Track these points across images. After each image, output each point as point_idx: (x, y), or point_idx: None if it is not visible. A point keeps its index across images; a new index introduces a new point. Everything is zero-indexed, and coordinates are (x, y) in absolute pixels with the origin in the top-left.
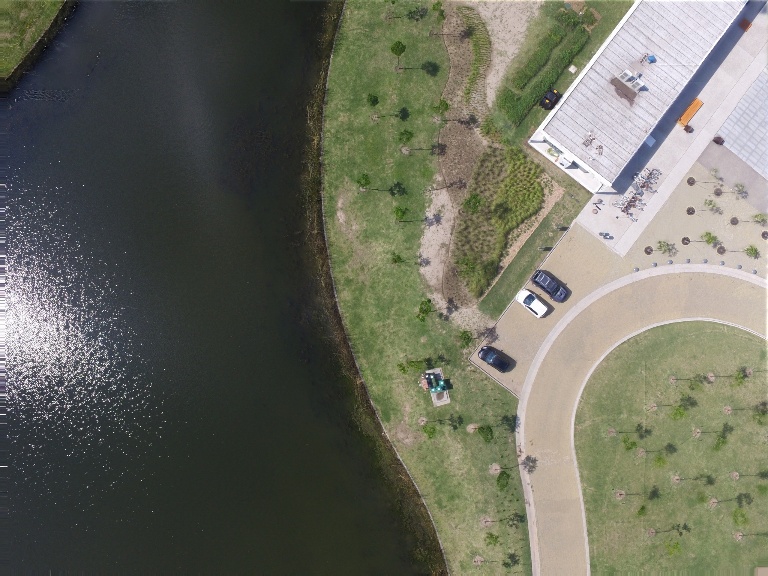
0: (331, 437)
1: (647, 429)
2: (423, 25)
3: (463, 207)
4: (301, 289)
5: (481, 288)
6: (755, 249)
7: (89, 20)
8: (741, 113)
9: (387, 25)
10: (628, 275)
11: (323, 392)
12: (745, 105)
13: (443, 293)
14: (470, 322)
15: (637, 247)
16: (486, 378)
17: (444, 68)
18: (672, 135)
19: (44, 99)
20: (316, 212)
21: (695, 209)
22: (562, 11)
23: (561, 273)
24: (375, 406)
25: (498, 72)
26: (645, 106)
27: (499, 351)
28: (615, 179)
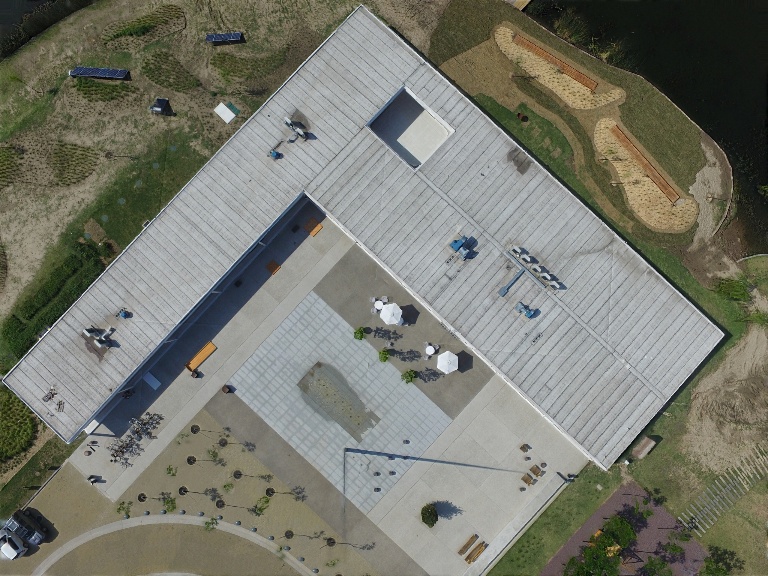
0: None
1: None
2: None
3: None
4: None
5: None
6: None
7: None
8: (258, 361)
9: None
10: (118, 521)
11: None
12: (263, 352)
13: None
14: None
15: (130, 493)
16: None
17: None
18: (180, 379)
19: None
20: None
21: (196, 458)
22: (76, 243)
23: (49, 512)
24: None
25: (9, 299)
26: (114, 363)
27: None
28: None
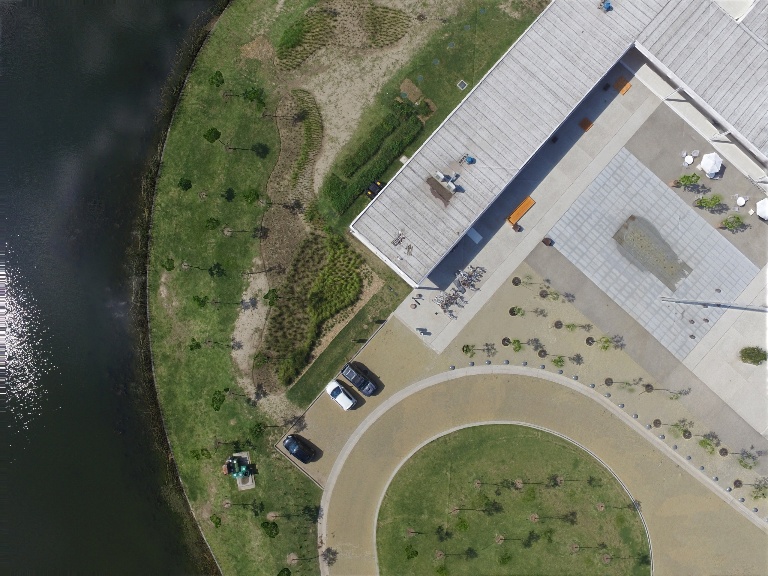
0: (140, 510)
1: (448, 532)
2: None
3: (280, 293)
4: (121, 360)
5: (288, 377)
6: (578, 355)
7: None
8: (574, 215)
9: (224, 102)
10: (443, 373)
11: (136, 464)
12: (579, 207)
13: (253, 378)
14: (277, 409)
15: (455, 345)
16: (291, 466)
17: (274, 150)
18: (500, 233)
19: None
20: (141, 284)
21: None
22: (396, 101)
23: (375, 366)
24: (183, 484)
25: (327, 158)
26: (460, 208)
27: (306, 440)
28: (435, 275)
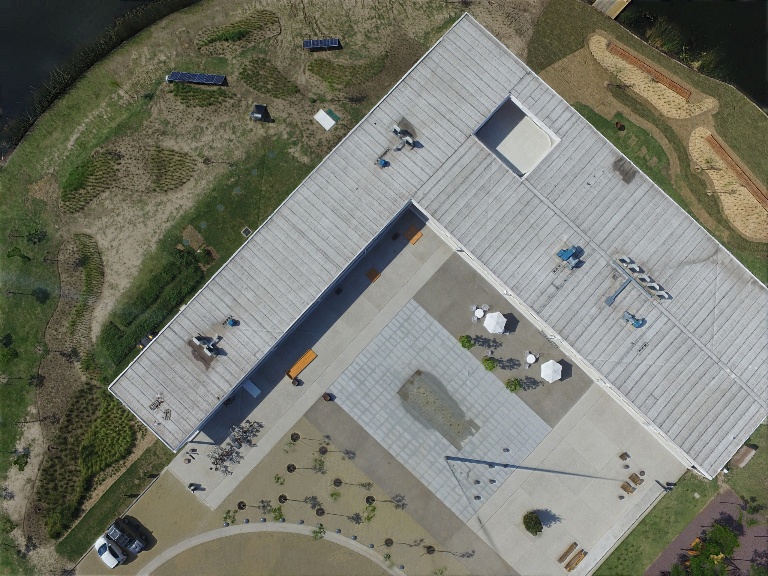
0: None
1: None
2: (39, 249)
3: (53, 443)
4: None
5: (55, 532)
6: (357, 514)
7: None
8: (358, 368)
9: (9, 243)
10: (217, 529)
11: None
12: (363, 360)
13: (24, 530)
14: (46, 563)
15: (230, 501)
16: None
17: (54, 296)
18: (280, 387)
19: None
20: None
21: (296, 466)
22: (175, 249)
23: (148, 520)
24: None
25: (107, 305)
26: (221, 371)
27: None
28: None
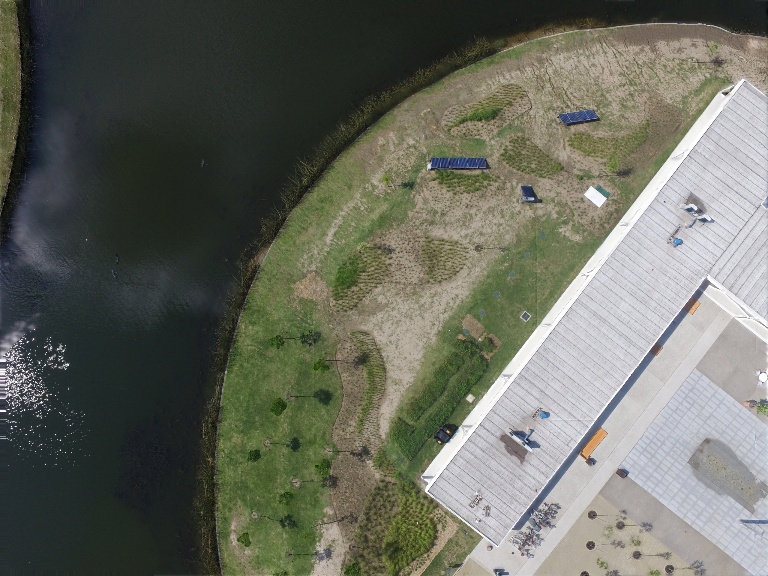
0: None
1: None
2: (316, 350)
3: (354, 542)
4: None
5: None
6: None
7: None
8: (648, 442)
9: None
10: None
11: None
12: (652, 434)
13: None
14: None
15: None
16: None
17: (337, 396)
18: (573, 467)
19: None
20: (210, 531)
21: (595, 543)
22: (459, 341)
23: None
24: None
25: (392, 402)
26: (536, 464)
27: None
28: None
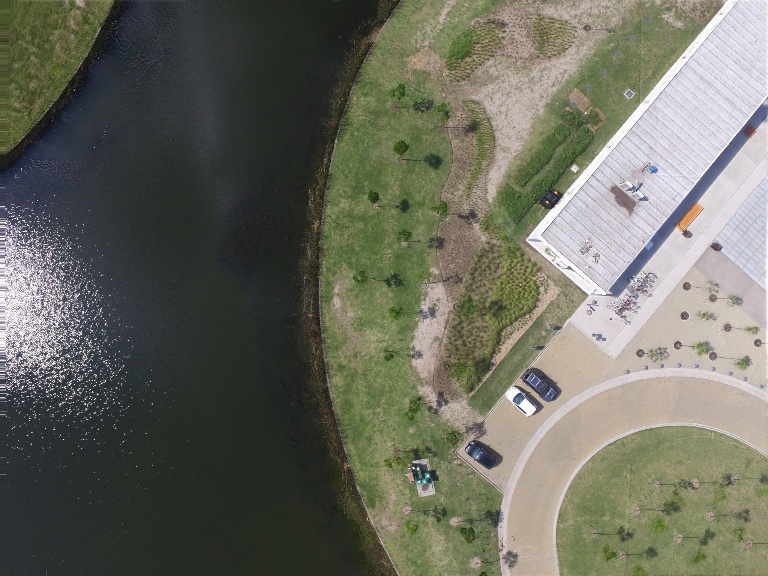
0: (316, 519)
1: (629, 532)
2: (428, 117)
3: (458, 302)
4: (294, 371)
5: (471, 385)
6: (747, 356)
7: (98, 93)
8: (741, 220)
9: (392, 114)
10: (619, 377)
11: (310, 474)
12: (745, 212)
13: (434, 386)
14: (459, 417)
15: (629, 349)
16: (472, 472)
17: (447, 161)
18: (670, 239)
19: (50, 169)
20: (312, 296)
21: (689, 314)
22: (567, 111)
23: (552, 372)
24: (361, 492)
25: (500, 168)
26: (644, 216)
27: (486, 446)
28: None
